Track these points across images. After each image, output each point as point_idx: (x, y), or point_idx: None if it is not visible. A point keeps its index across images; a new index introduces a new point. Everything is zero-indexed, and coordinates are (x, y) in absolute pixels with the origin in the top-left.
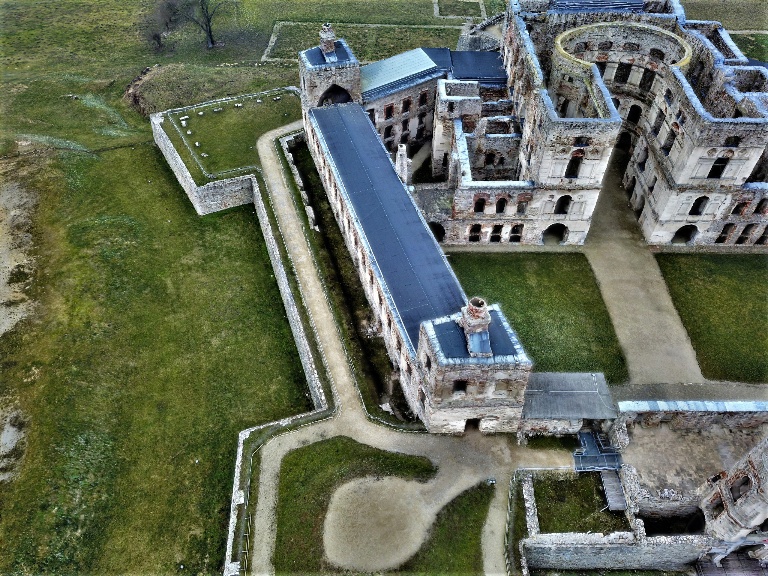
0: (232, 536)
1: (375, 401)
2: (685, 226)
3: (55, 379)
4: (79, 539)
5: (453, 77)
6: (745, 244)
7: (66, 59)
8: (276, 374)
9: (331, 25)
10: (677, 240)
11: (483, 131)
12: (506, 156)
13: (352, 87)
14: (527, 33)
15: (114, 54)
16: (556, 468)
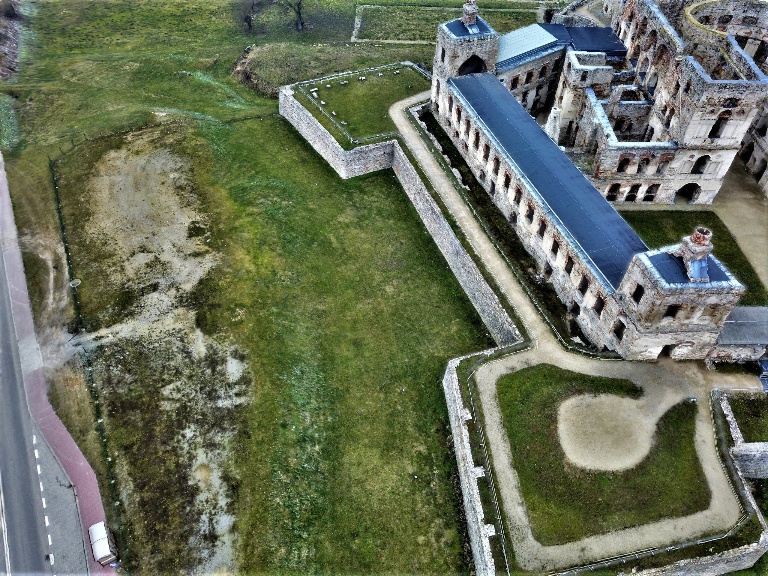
0: (469, 446)
1: (566, 334)
2: None
3: (261, 319)
4: (319, 453)
5: (576, 50)
6: None
7: (163, 40)
8: (453, 317)
9: (410, 8)
10: None
11: (618, 98)
12: (635, 122)
13: (489, 58)
14: (656, 7)
15: (207, 35)
16: (746, 389)
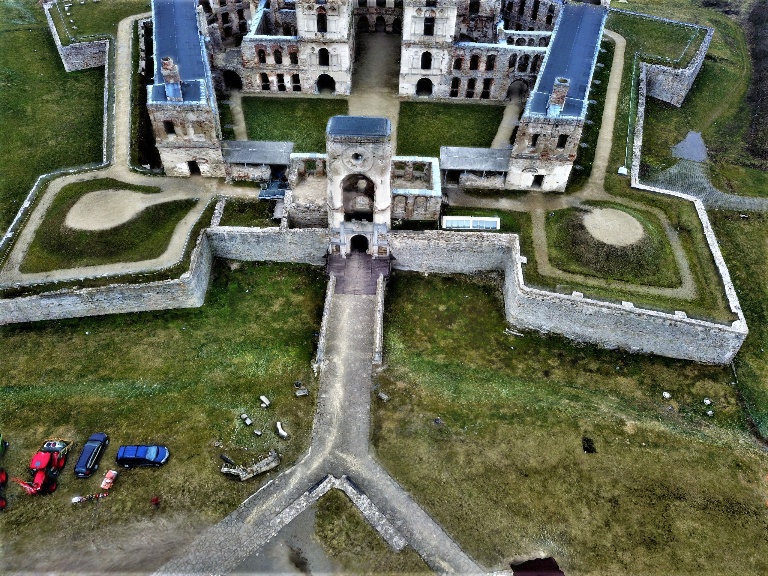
0: (15, 222)
1: (140, 162)
2: (422, 79)
3: None
4: None
5: None
6: (474, 98)
7: None
8: (89, 161)
9: None
10: (423, 94)
11: (276, 6)
12: None
13: None
14: None
15: None
16: (245, 196)
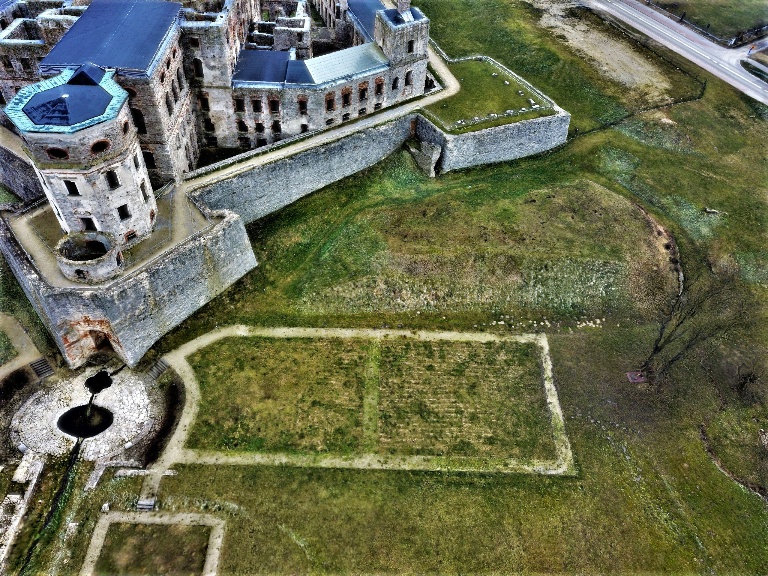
0: None
1: None
2: None
3: (502, 3)
4: None
5: None
6: None
7: None
8: None
9: (458, 460)
10: None
11: None
12: None
13: None
14: None
15: None
16: None
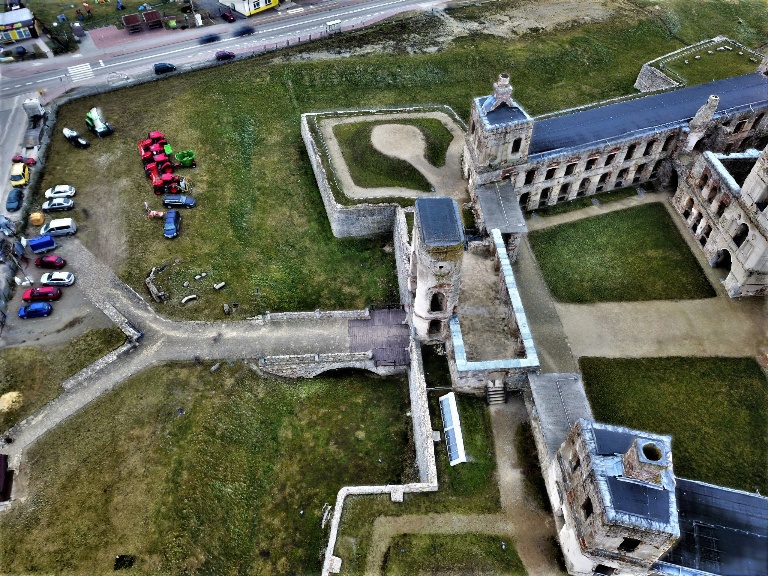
0: None
1: None
2: None
3: (468, 53)
4: (387, 82)
5: None
6: None
7: None
8: None
9: None
10: None
11: None
12: None
13: None
14: None
15: None
16: None
